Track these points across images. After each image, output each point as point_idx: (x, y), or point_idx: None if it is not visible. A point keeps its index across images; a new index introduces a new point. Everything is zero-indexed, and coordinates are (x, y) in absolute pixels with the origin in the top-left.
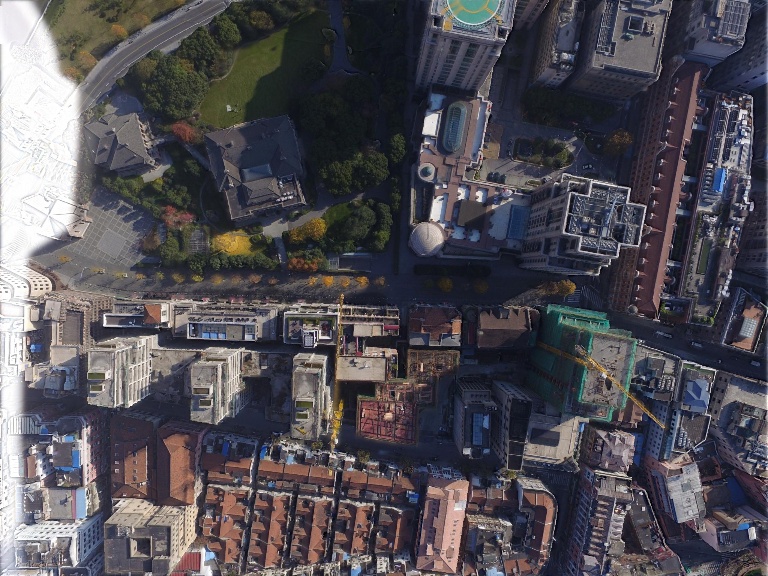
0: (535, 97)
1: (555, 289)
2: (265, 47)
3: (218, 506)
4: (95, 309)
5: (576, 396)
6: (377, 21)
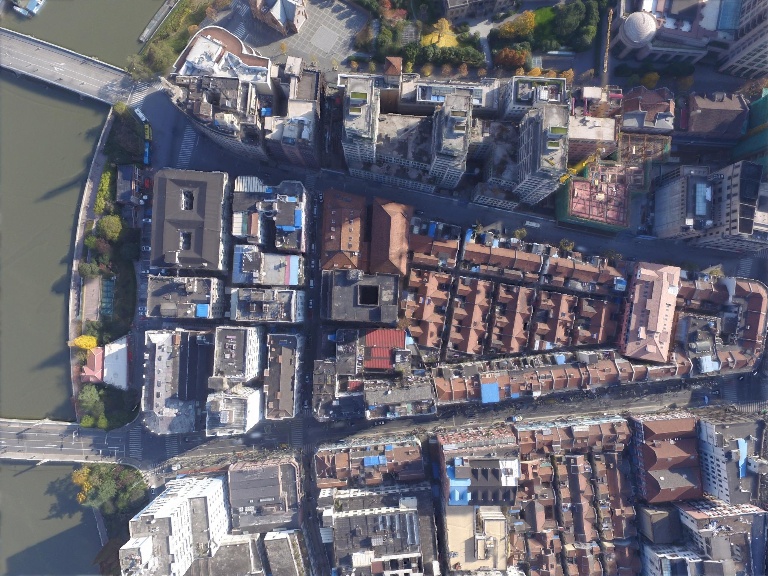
0: None
1: (764, 81)
2: None
3: (421, 289)
4: None
5: None
6: None
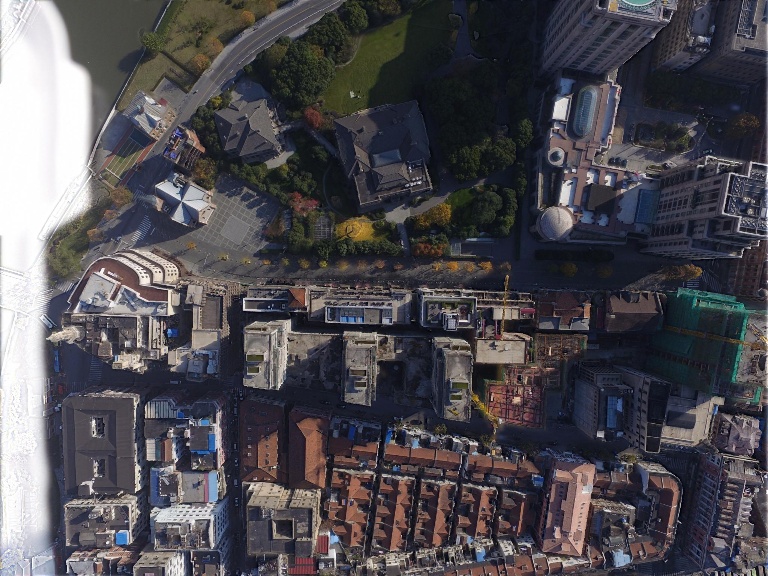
0: (663, 81)
1: (682, 273)
2: (388, 33)
3: (343, 490)
4: (229, 294)
5: (728, 377)
6: (502, 6)
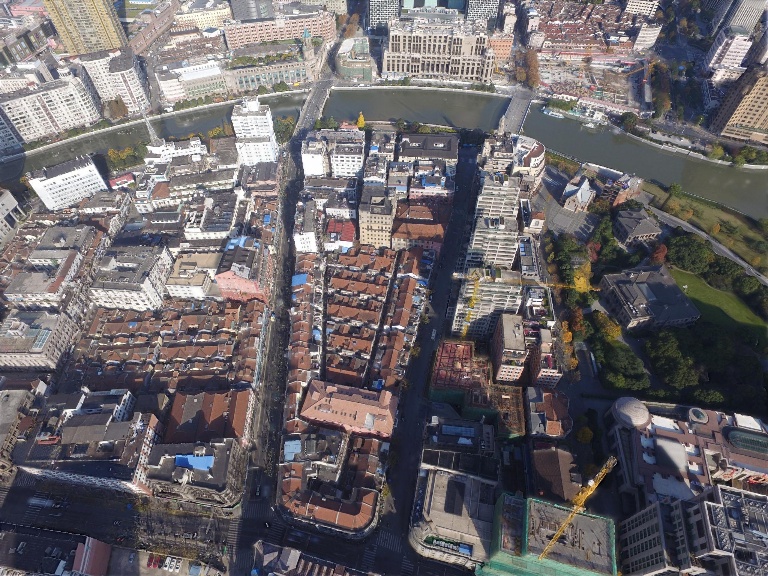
0: None
1: None
2: (746, 312)
3: None
4: None
5: None
6: None
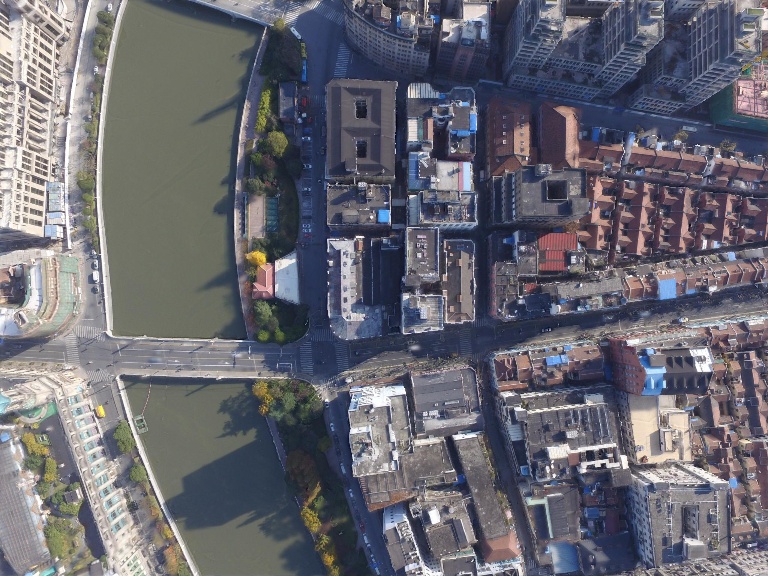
0: None
1: None
2: None
3: (587, 193)
4: None
5: None
6: None
